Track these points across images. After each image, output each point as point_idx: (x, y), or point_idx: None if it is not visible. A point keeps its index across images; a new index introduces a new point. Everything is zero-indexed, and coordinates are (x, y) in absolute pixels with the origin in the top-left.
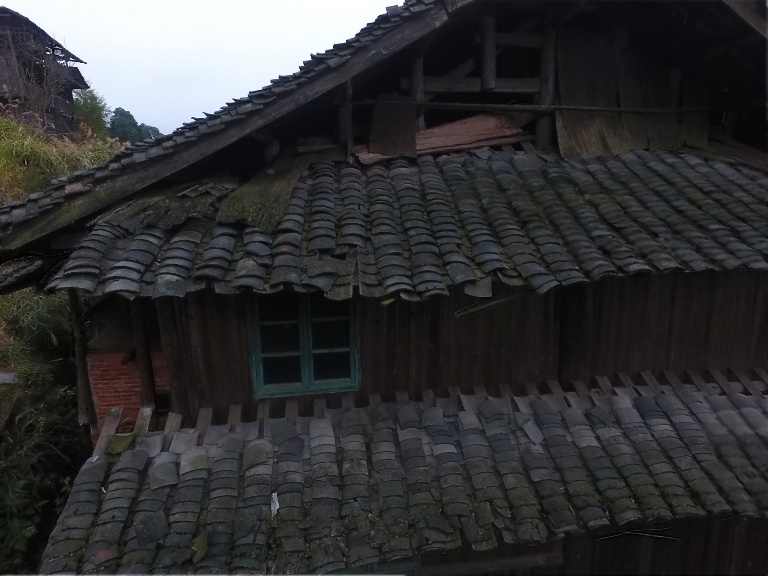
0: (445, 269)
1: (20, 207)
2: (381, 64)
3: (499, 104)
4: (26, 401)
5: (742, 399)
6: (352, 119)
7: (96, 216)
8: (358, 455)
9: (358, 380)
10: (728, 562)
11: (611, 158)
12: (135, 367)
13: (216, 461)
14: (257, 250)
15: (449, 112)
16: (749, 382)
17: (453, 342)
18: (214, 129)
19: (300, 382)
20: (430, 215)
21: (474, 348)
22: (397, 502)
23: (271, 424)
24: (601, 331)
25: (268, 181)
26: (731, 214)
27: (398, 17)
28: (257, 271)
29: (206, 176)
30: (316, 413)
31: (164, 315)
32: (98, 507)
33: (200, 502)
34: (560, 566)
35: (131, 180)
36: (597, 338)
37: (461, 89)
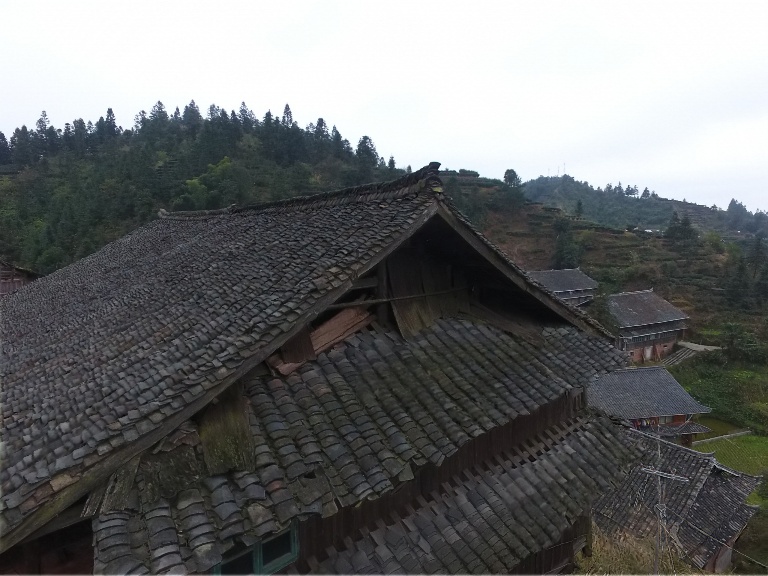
0: (382, 465)
1: None
2: None
3: (356, 300)
4: None
5: (514, 473)
6: None
7: (84, 501)
8: None
9: (297, 551)
10: (514, 572)
11: (428, 332)
12: None
13: None
14: (258, 494)
15: (326, 312)
16: (513, 458)
17: None
18: (198, 396)
19: (253, 573)
20: (350, 416)
21: None
22: None
23: None
24: None
25: (221, 413)
26: (498, 369)
27: (325, 290)
28: (269, 515)
29: None
30: None
31: None
32: None
33: None
34: None
35: (119, 457)
36: None
37: None
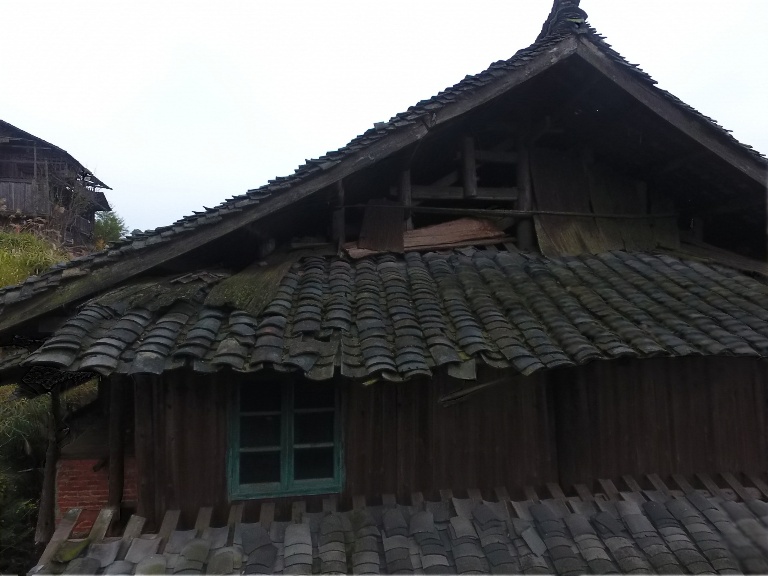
0: (429, 351)
1: (15, 290)
2: (371, 173)
3: (481, 209)
4: None
5: (761, 506)
6: (344, 221)
7: (88, 299)
8: (337, 567)
9: (342, 480)
10: None
11: (590, 257)
12: (107, 475)
13: (175, 572)
14: (241, 330)
15: (435, 215)
16: (766, 487)
17: (443, 438)
18: (212, 221)
19: (279, 481)
20: (415, 303)
21: (466, 445)
22: None
23: (243, 530)
24: (599, 428)
25: (260, 271)
26: (711, 306)
27: (384, 130)
28: (238, 350)
29: (201, 267)
30: (294, 518)
31: (141, 403)
32: None
33: None
34: None
35: (127, 266)
36: (595, 435)
37: (445, 196)
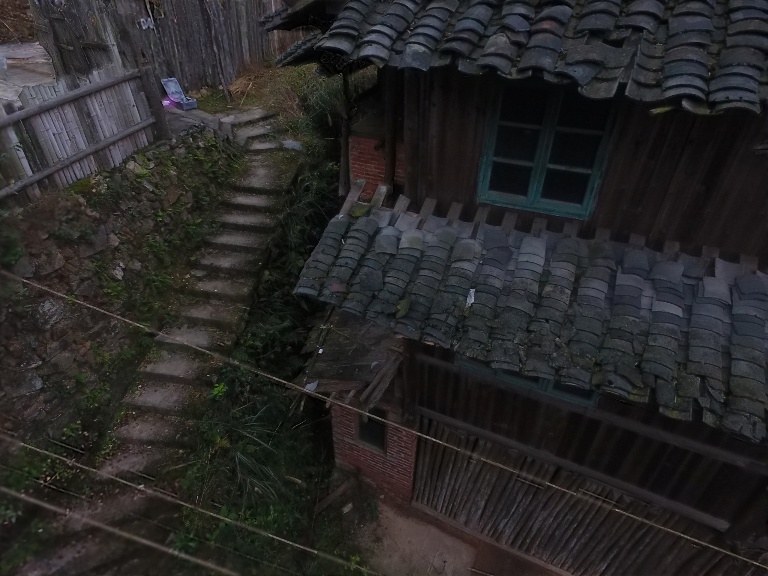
0: None
1: None
2: None
3: None
4: (306, 167)
5: None
6: None
7: None
8: (564, 283)
9: (590, 209)
10: None
11: None
12: None
13: (430, 246)
14: (514, 24)
15: None
16: None
17: (736, 191)
18: None
19: (525, 196)
20: None
21: (765, 206)
22: (590, 339)
23: (486, 229)
24: None
25: None
26: None
27: None
28: (507, 50)
29: None
30: (533, 231)
31: (410, 97)
32: (338, 253)
33: (410, 275)
34: (764, 477)
35: None
36: None
37: None
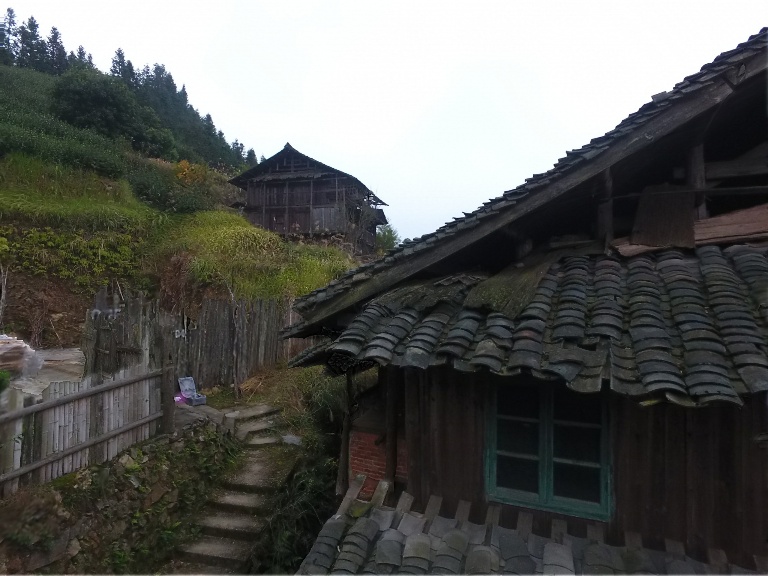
0: (736, 373)
1: (323, 291)
2: (648, 155)
3: None
4: (304, 462)
5: None
6: (612, 214)
7: (370, 299)
8: None
9: (610, 509)
10: None
11: None
12: None
13: (438, 555)
14: (498, 333)
15: (742, 197)
16: None
17: (759, 488)
18: (470, 225)
19: (537, 493)
20: (713, 309)
21: None
22: None
23: (500, 533)
24: None
25: (517, 273)
26: None
27: (666, 101)
28: (496, 352)
29: (461, 270)
30: (553, 536)
31: (410, 393)
32: (332, 564)
33: None
34: None
35: (399, 270)
36: None
37: (760, 171)
